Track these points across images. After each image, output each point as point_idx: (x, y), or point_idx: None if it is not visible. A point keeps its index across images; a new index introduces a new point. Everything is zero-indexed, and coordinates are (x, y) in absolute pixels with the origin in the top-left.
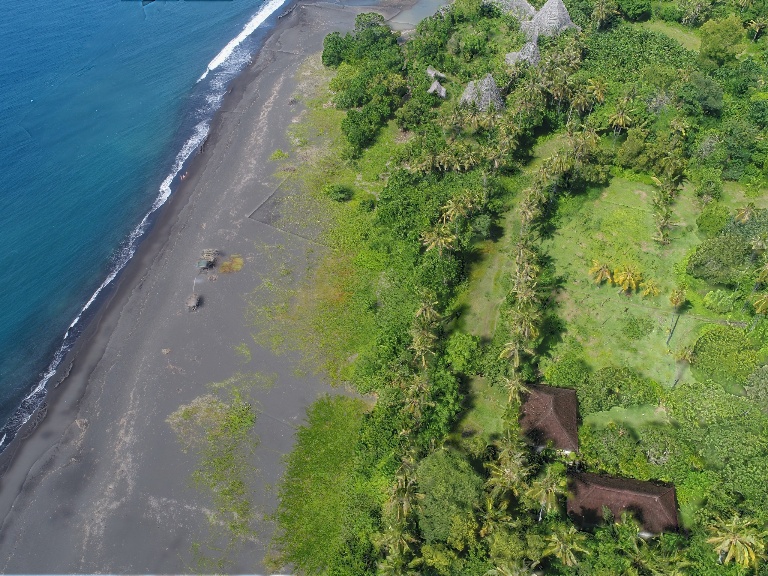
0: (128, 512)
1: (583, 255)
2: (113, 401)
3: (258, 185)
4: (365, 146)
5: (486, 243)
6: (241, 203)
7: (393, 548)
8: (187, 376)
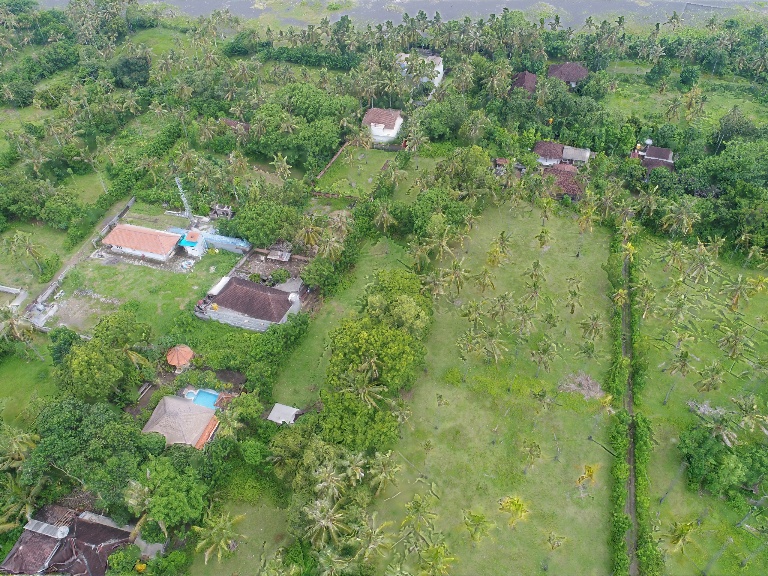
0: (499, 1)
1: (724, 108)
2: None
3: (722, 2)
4: None
5: (715, 75)
6: None
7: (488, 21)
8: (564, 2)
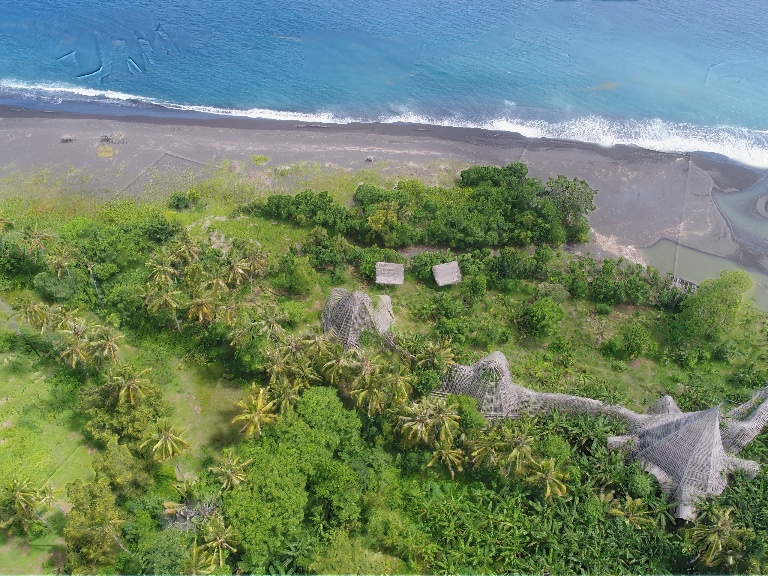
0: None
1: None
2: (4, 126)
3: (212, 153)
4: (282, 221)
5: None
6: (188, 147)
7: None
8: None
